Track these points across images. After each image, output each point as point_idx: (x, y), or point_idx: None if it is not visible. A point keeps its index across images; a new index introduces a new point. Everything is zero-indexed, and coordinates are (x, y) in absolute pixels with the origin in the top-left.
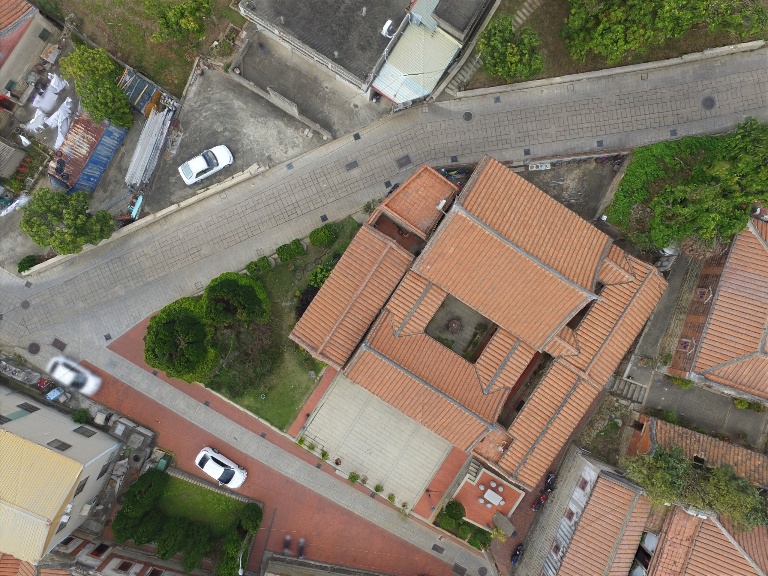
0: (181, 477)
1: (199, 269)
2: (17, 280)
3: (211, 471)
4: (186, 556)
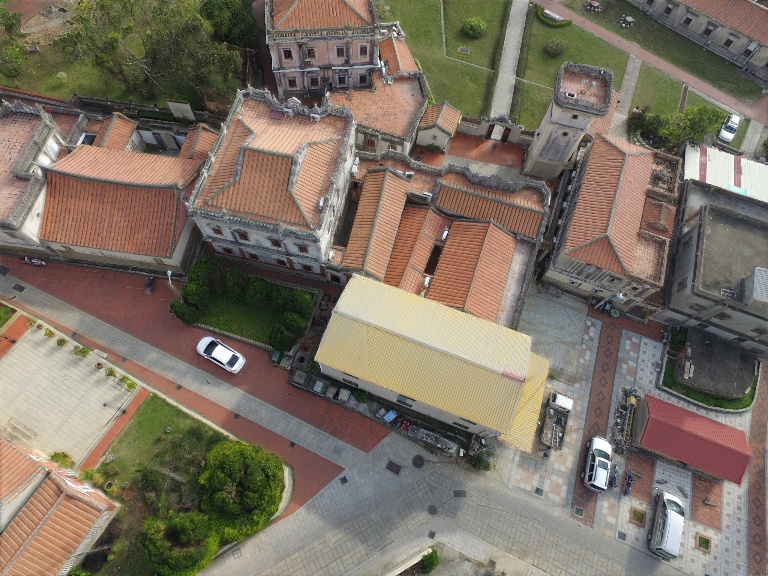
0: (260, 344)
1: (235, 575)
2: (444, 539)
3: (224, 353)
4: (238, 281)
